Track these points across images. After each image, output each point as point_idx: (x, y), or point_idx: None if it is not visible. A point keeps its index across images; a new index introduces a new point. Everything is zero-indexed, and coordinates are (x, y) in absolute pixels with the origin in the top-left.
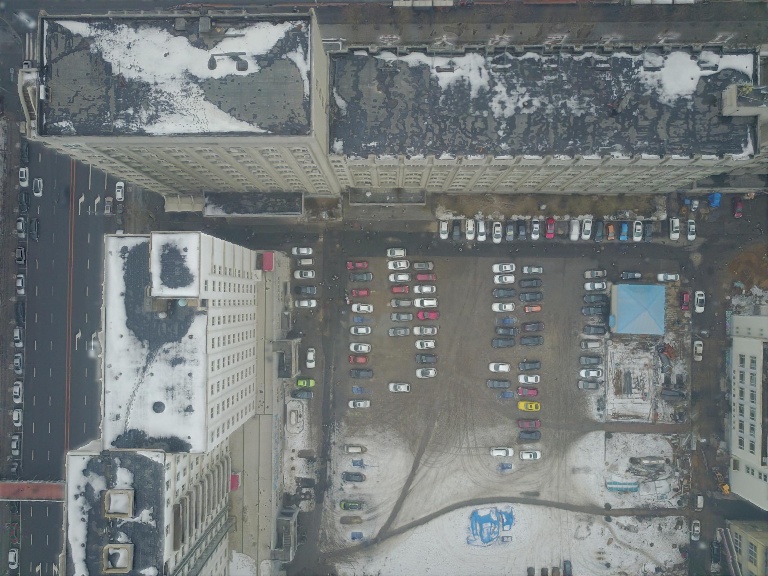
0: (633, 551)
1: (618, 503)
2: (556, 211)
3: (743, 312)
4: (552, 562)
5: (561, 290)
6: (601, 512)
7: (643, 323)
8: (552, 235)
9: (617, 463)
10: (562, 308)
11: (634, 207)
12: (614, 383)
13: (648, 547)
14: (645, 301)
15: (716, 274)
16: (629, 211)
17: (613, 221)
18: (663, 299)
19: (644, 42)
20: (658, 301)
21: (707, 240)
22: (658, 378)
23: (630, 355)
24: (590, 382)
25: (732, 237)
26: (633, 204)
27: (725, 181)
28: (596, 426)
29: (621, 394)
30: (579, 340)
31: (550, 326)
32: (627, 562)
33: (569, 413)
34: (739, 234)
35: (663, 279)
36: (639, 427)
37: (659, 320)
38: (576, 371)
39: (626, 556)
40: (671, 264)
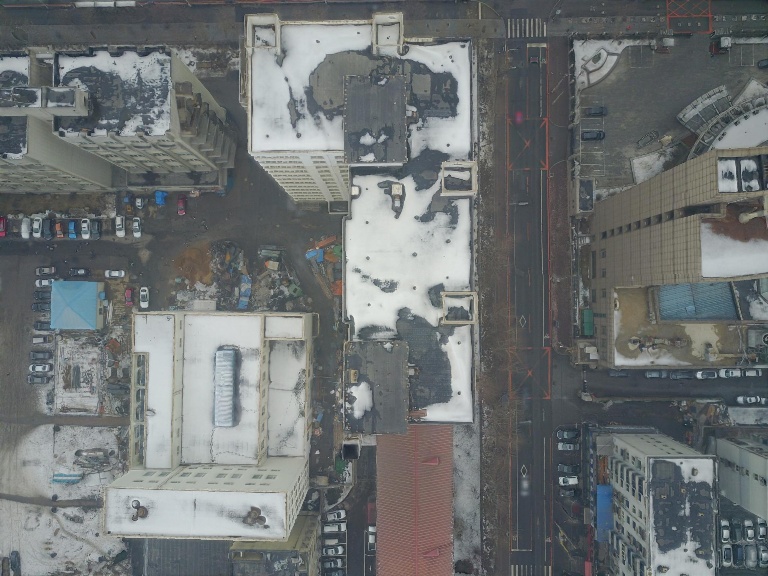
0: (79, 541)
1: (65, 494)
2: (11, 210)
3: (187, 307)
4: (2, 553)
5: (15, 287)
6: (50, 503)
7: (70, 318)
8: (3, 233)
9: (65, 455)
10: (16, 304)
11: (85, 205)
12: (63, 377)
13: (93, 537)
14: (70, 297)
15: (163, 270)
16: (80, 209)
17: (66, 219)
18: (93, 295)
19: (96, 44)
20: (85, 297)
21: (155, 237)
22: (106, 372)
23: (80, 350)
24: (37, 376)
25: (179, 234)
26: (83, 202)
27: (156, 179)
28: (47, 419)
29: (70, 388)
30: (31, 336)
31: (4, 322)
32: (73, 552)
33: (21, 407)
34: (185, 231)
35: (108, 275)
36: (87, 420)
37: (86, 315)
38: (28, 366)
39: (69, 546)
40: (120, 261)
